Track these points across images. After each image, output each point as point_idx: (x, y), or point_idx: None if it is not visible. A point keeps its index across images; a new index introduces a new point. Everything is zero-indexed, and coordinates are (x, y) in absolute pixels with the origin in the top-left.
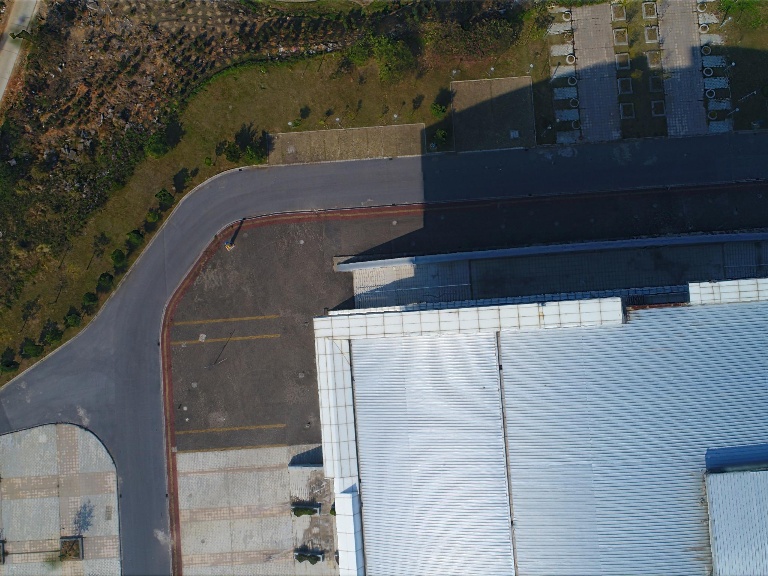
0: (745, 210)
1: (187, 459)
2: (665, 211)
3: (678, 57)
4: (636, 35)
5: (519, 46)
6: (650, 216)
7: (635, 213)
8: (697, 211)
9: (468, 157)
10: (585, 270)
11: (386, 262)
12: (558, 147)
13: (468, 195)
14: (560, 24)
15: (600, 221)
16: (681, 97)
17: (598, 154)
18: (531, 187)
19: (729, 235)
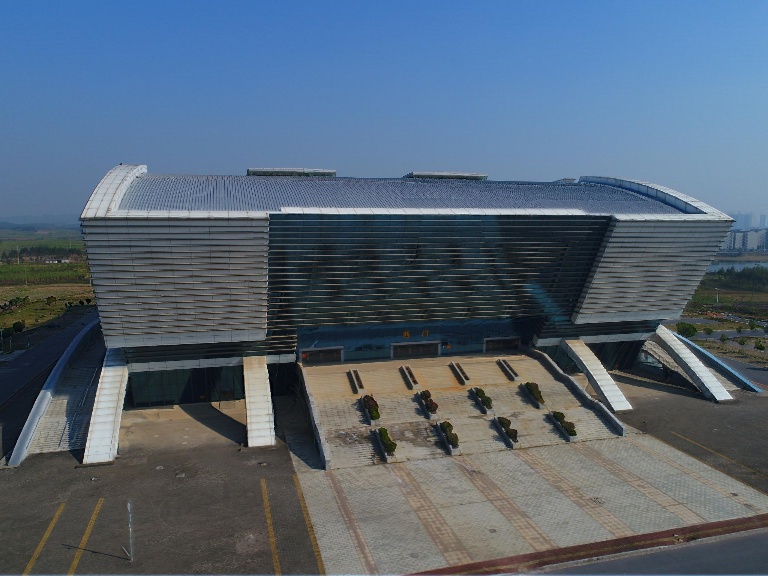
0: None
1: (339, 570)
2: None
3: None
4: None
5: None
6: None
7: None
8: None
9: None
10: None
11: (34, 412)
12: None
13: None
14: None
15: None
16: None
17: None
18: None
19: None
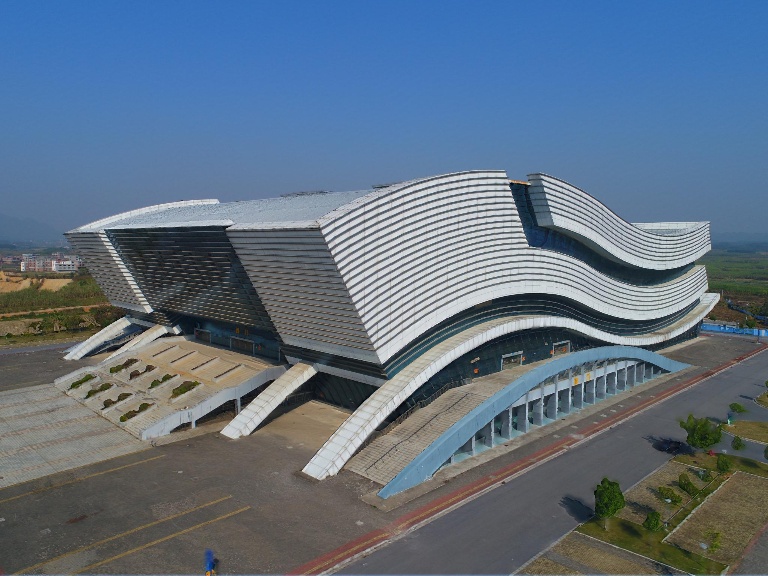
0: None
1: None
2: None
3: None
4: None
5: None
6: None
7: None
8: None
9: None
10: None
11: None
12: None
13: None
14: None
15: None
16: None
17: None
18: None
19: None
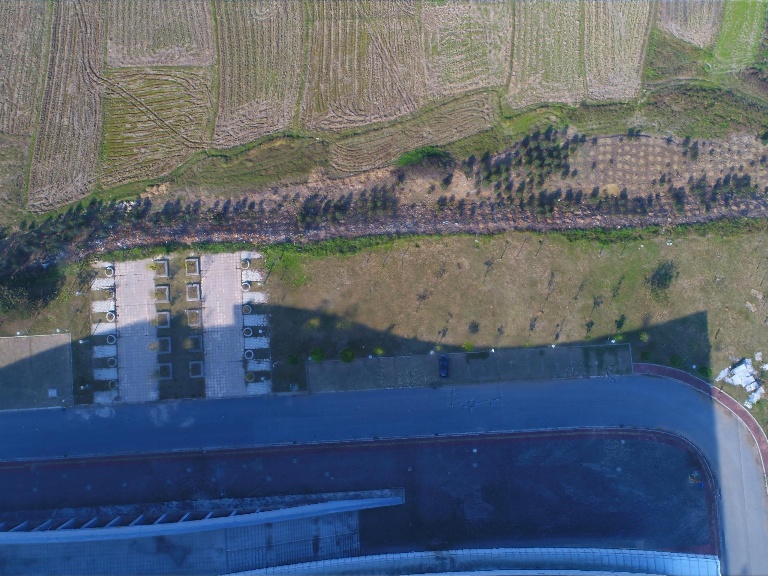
0: (278, 476)
1: None
2: (198, 476)
3: (219, 316)
4: (178, 292)
5: (60, 302)
6: (183, 481)
7: (168, 477)
8: (230, 476)
9: (5, 416)
10: (87, 552)
11: None
12: (96, 407)
13: (4, 455)
14: (103, 279)
15: (132, 485)
16: (220, 357)
17: (135, 415)
18: (67, 448)
19: (225, 522)
